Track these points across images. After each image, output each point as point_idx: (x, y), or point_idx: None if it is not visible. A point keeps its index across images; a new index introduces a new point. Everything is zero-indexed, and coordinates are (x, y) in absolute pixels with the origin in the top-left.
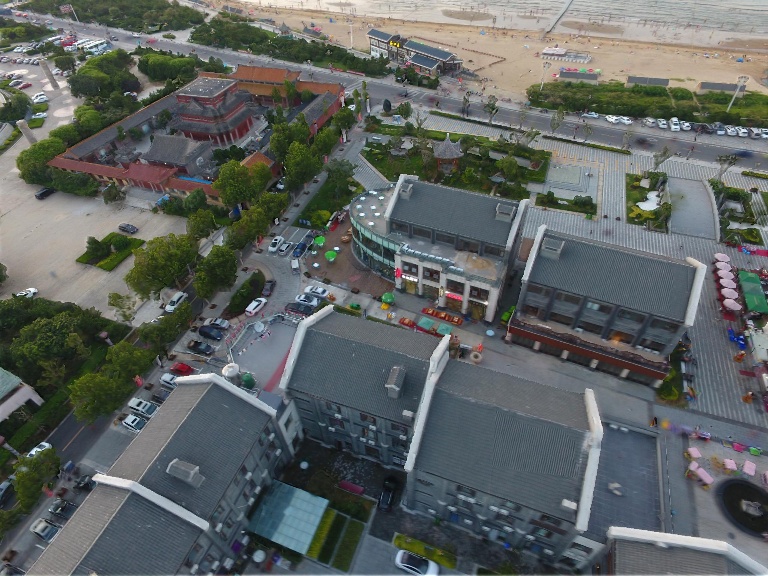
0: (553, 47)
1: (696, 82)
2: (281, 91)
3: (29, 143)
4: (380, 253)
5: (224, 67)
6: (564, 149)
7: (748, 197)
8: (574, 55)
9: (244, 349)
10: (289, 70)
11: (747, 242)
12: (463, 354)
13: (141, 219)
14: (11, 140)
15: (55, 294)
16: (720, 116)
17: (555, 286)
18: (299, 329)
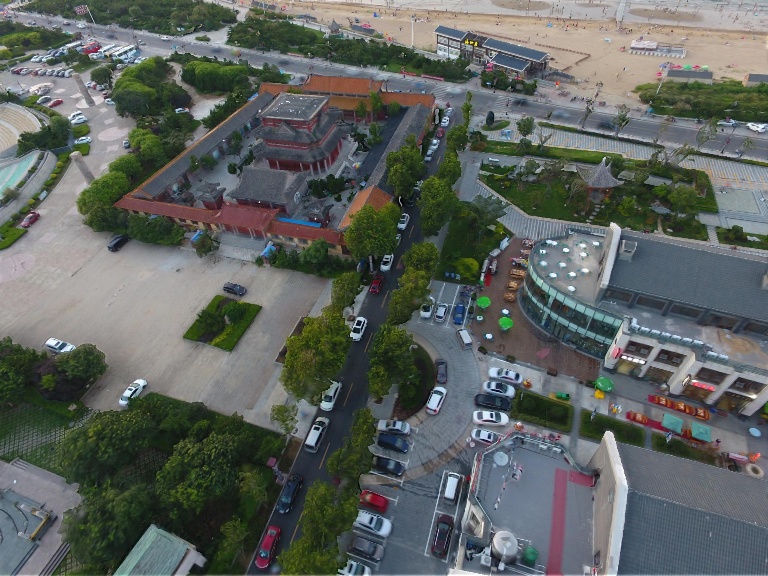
0: (641, 40)
1: None
2: (367, 105)
3: (84, 178)
4: (583, 325)
5: (281, 74)
6: (717, 167)
7: None
8: (668, 49)
9: (498, 499)
10: (372, 79)
11: None
12: (737, 467)
13: (245, 275)
14: (58, 173)
15: (170, 386)
16: None
17: None
18: (620, 494)
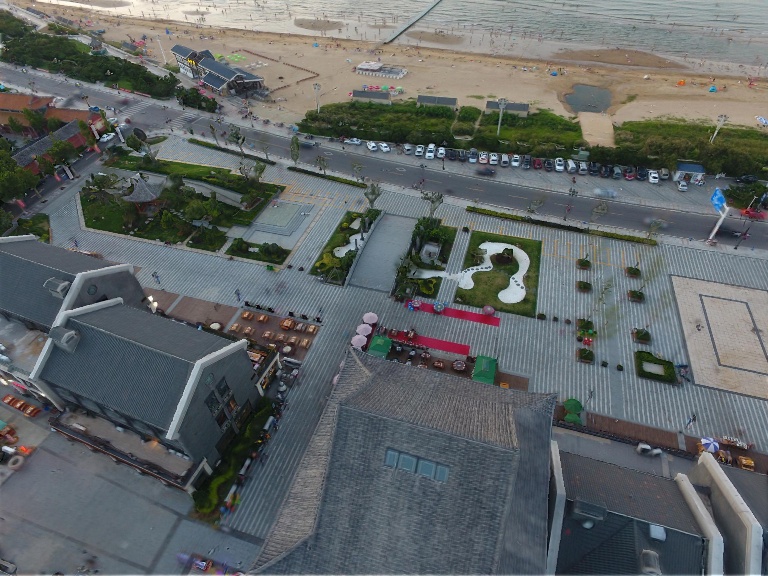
0: (370, 61)
1: (494, 99)
2: (21, 120)
3: None
4: None
5: (1, 89)
6: (301, 183)
7: (446, 240)
8: (388, 70)
9: None
10: (35, 96)
11: (420, 295)
12: (2, 459)
13: None
14: None
15: None
16: (476, 142)
17: (62, 385)
18: None
